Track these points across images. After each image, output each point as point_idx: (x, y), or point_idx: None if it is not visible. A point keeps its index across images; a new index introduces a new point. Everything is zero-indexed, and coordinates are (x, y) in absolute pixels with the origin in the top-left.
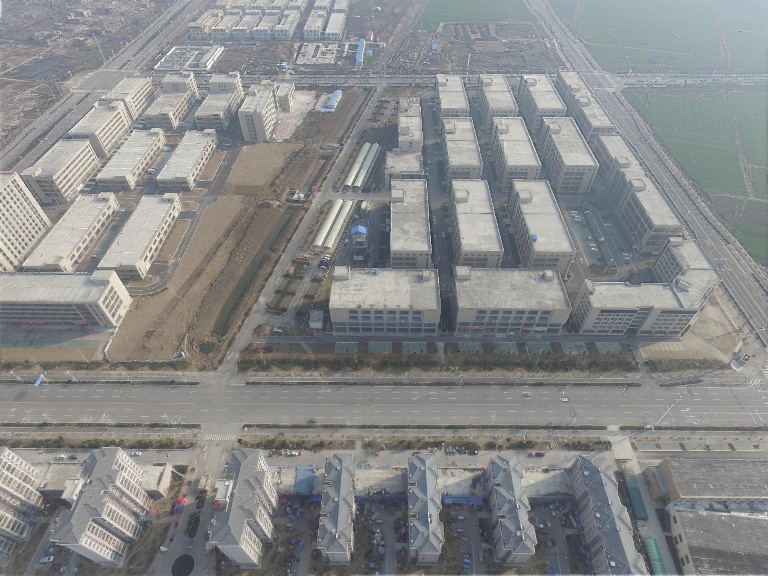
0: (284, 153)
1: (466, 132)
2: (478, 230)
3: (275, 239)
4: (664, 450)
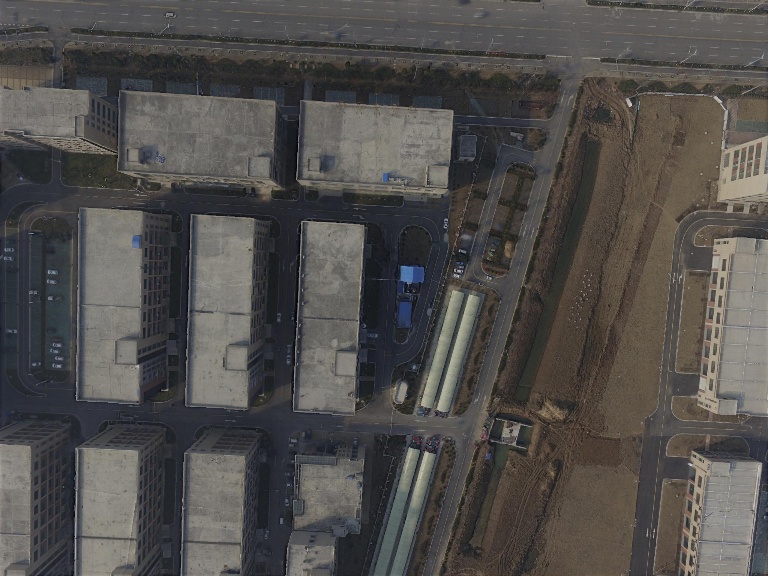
0: (548, 567)
1: (199, 575)
2: (223, 269)
3: (539, 326)
4: None
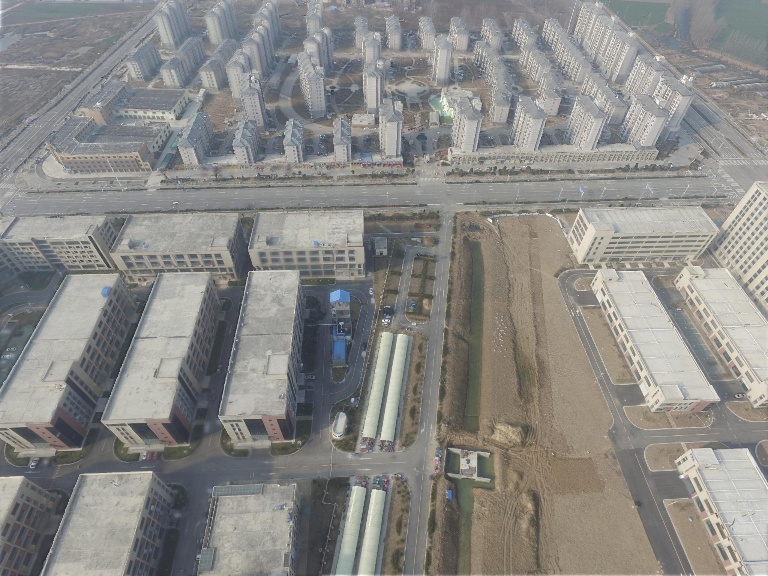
0: None
1: None
2: (175, 306)
3: (469, 360)
4: (127, 180)
